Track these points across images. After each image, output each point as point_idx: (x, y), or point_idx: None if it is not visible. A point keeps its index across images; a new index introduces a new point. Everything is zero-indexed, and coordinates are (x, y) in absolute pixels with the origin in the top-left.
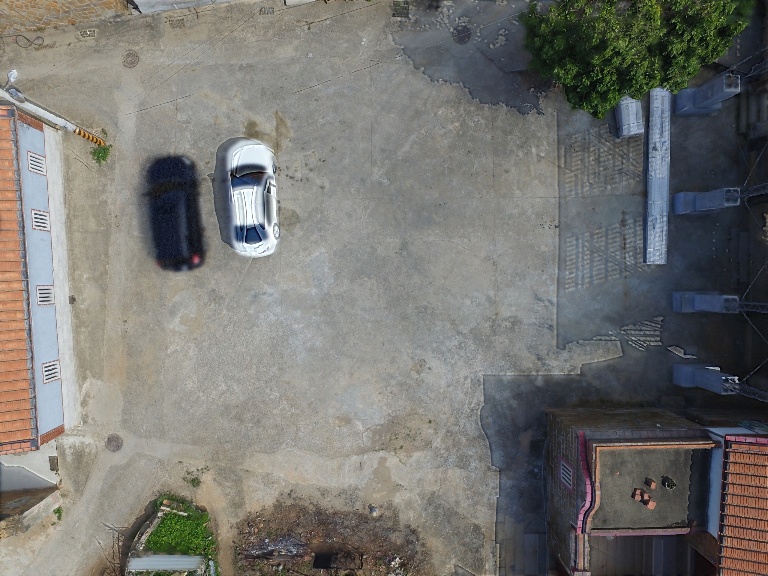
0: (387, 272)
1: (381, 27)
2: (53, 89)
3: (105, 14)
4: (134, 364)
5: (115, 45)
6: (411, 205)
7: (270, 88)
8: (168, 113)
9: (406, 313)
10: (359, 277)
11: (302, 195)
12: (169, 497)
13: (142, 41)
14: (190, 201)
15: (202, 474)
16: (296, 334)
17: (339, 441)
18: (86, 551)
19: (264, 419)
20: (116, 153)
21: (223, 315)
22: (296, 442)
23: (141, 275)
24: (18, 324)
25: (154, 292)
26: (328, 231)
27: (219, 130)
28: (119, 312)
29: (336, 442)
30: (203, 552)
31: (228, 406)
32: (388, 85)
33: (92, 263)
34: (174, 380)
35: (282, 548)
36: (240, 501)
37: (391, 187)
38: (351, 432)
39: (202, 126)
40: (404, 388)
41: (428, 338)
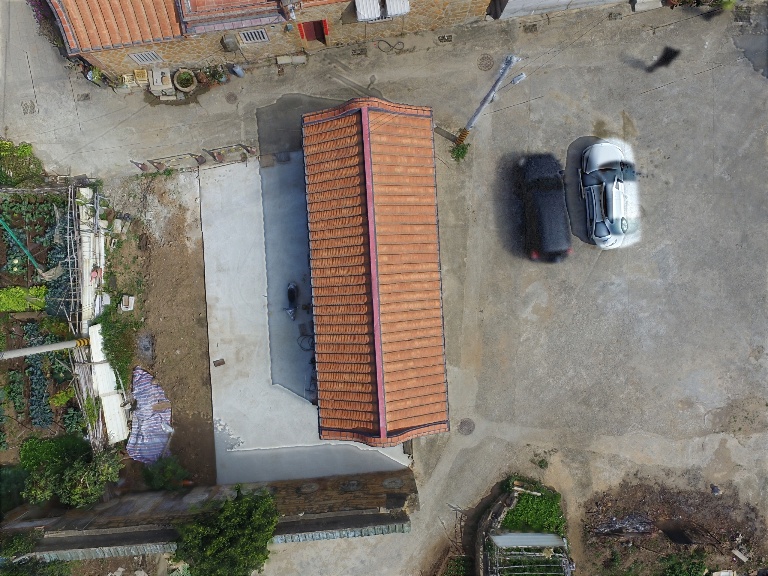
0: (728, 263)
1: (723, 31)
2: (413, 91)
3: (467, 20)
4: (489, 352)
5: (471, 49)
6: (751, 199)
7: (617, 89)
8: (521, 113)
9: (745, 302)
10: (701, 268)
11: (648, 190)
12: (519, 478)
13: (497, 45)
14: (543, 197)
15: (550, 456)
16: (642, 322)
17: (682, 424)
18: (429, 531)
19: (611, 403)
20: (474, 152)
21: (573, 305)
22: (642, 425)
23: (497, 267)
24: (437, 312)
25: (509, 283)
26: (673, 224)
27: (570, 129)
28: (476, 302)
29: (679, 425)
30: (555, 530)
31: (576, 391)
32: (729, 86)
33: (451, 256)
34: (526, 367)
35: (629, 526)
36: (587, 481)
37: (732, 183)
38: (693, 415)
39: (554, 126)
40: (743, 373)
41: (766, 325)
